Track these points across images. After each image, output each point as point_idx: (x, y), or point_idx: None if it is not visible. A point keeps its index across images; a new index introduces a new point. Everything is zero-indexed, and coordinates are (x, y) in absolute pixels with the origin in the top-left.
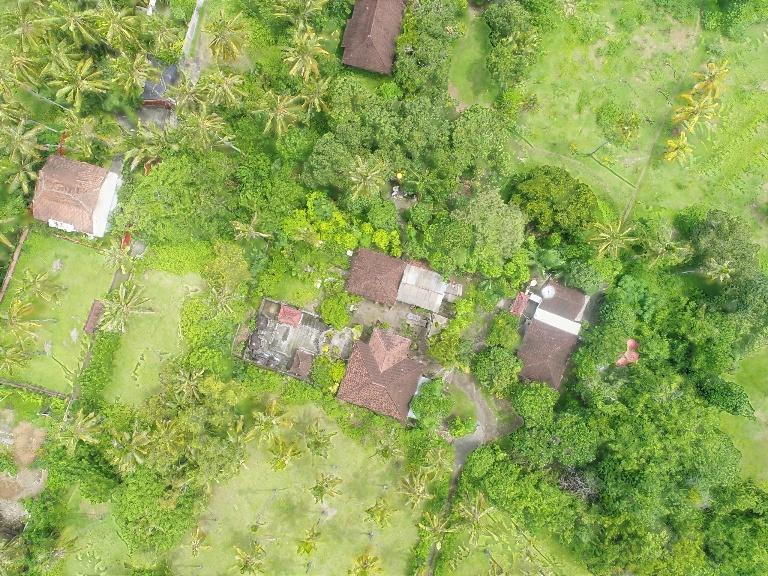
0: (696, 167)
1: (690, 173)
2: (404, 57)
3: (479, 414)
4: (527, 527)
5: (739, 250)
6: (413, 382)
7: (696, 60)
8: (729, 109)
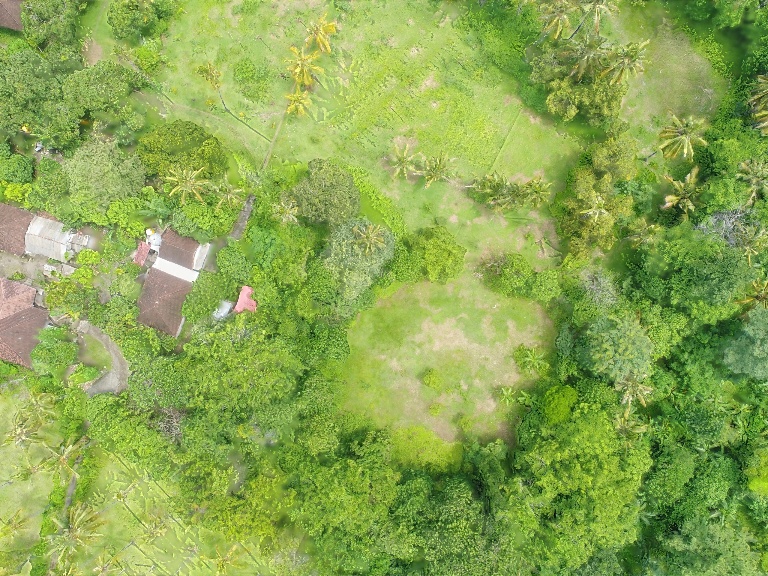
0: (330, 121)
1: (324, 127)
2: (27, 13)
3: (114, 363)
4: (152, 472)
5: (325, 196)
6: (37, 330)
7: (327, 17)
8: (360, 65)
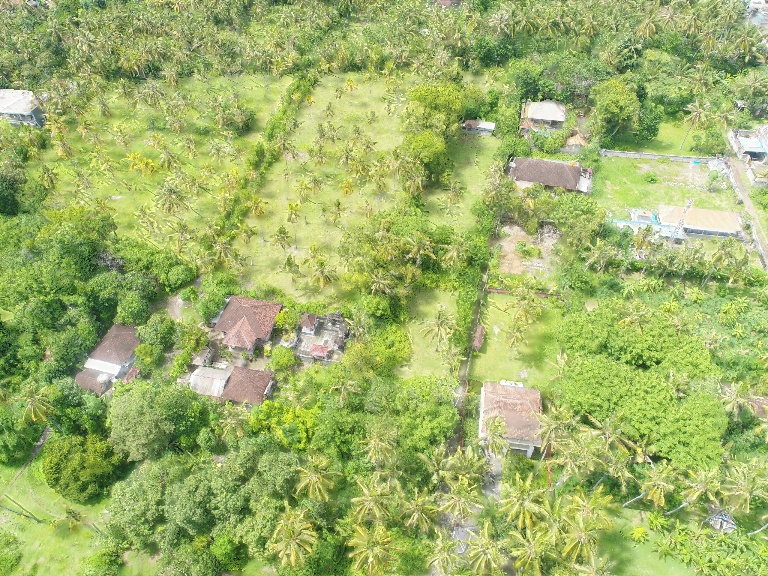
0: None
1: None
2: None
3: (179, 311)
4: None
5: None
6: None
7: None
8: None
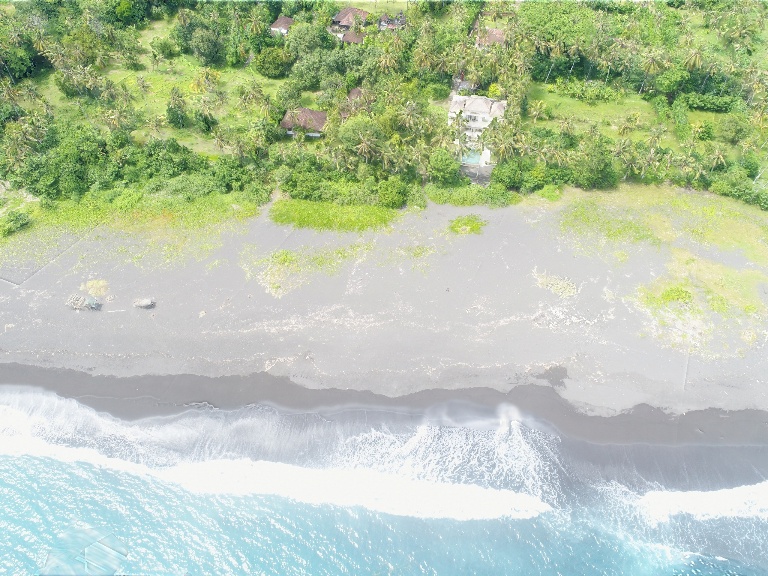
0: None
1: None
2: None
3: None
4: None
5: None
6: None
7: None
8: None
